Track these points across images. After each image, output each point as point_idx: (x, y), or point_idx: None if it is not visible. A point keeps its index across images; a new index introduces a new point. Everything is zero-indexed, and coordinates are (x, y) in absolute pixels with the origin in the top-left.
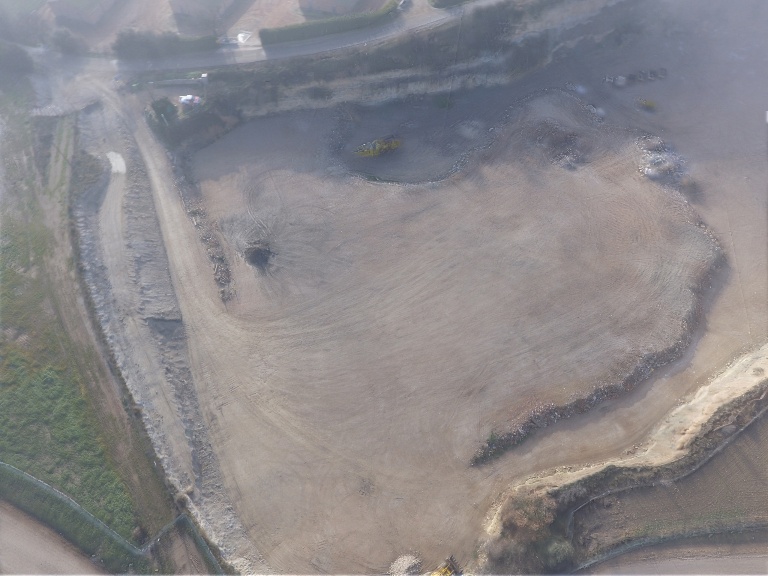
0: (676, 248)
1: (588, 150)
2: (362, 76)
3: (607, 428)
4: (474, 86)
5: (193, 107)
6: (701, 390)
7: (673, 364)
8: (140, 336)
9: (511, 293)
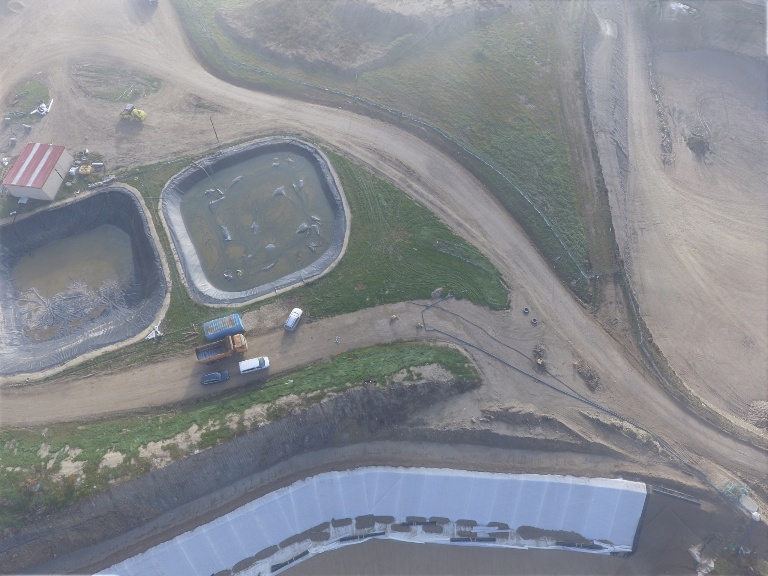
0: None
1: None
2: None
3: None
4: None
5: (687, 16)
6: None
7: None
8: (608, 149)
9: None
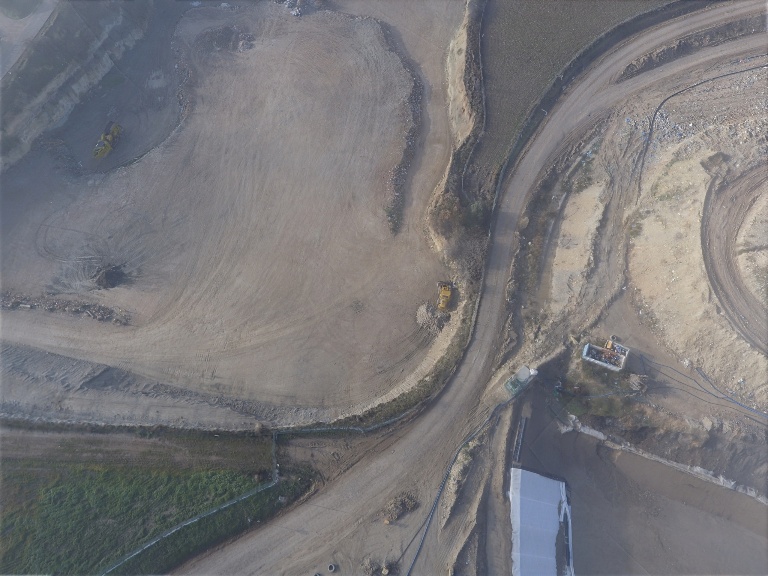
0: (360, 38)
1: (252, 28)
2: (35, 99)
3: (432, 151)
4: (130, 50)
5: None
6: (449, 90)
7: (424, 94)
8: (92, 400)
9: (306, 137)
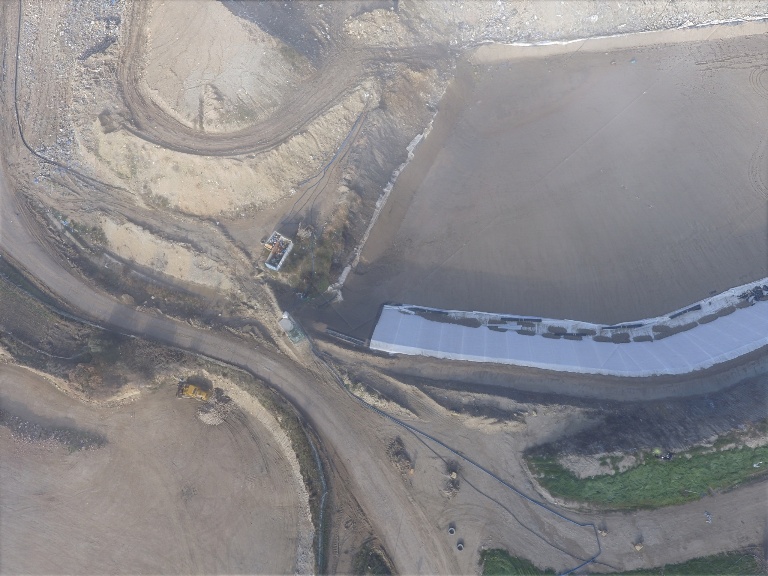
0: None
1: None
2: None
3: (6, 388)
4: None
5: None
6: None
7: None
8: None
9: None
